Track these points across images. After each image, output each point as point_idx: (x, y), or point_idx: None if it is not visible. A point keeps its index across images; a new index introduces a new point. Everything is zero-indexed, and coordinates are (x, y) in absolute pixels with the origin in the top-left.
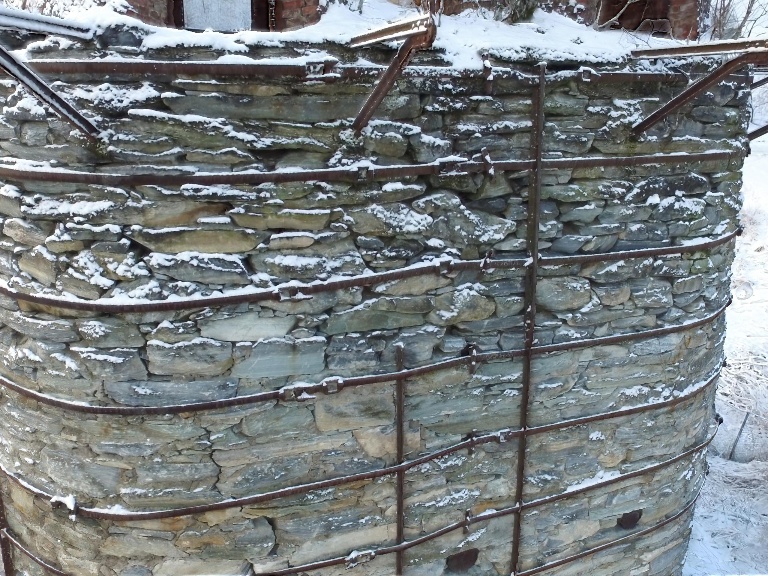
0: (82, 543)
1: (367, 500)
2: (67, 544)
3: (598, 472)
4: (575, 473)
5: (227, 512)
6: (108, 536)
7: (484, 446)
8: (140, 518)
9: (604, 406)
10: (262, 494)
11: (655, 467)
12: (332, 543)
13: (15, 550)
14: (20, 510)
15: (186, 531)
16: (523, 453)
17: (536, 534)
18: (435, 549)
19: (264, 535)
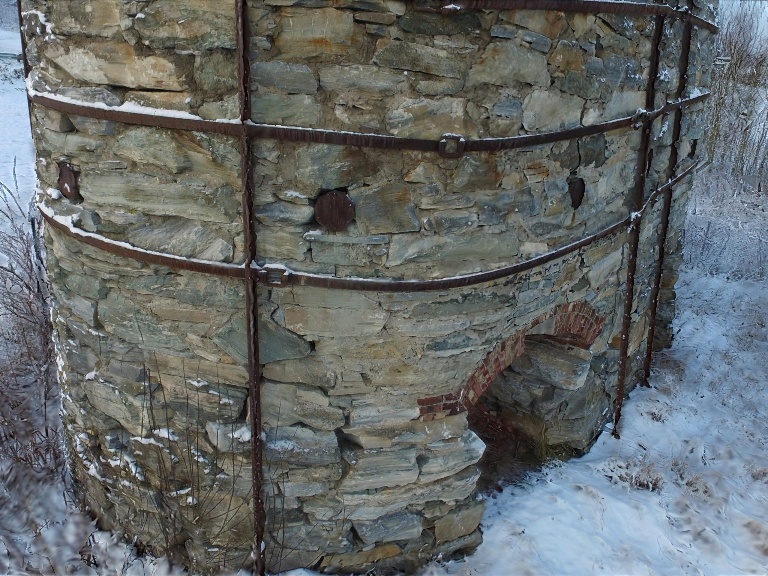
0: (447, 65)
1: (639, 52)
2: (420, 74)
3: (695, 87)
4: (691, 82)
5: (587, 20)
6: (487, 44)
7: (675, 24)
8: (534, 4)
9: (702, 17)
10: (612, 0)
11: (708, 94)
12: (623, 99)
13: (259, 164)
14: (308, 54)
15: (561, 39)
16: (690, 38)
17: (674, 144)
18: (652, 135)
19: (600, 67)
